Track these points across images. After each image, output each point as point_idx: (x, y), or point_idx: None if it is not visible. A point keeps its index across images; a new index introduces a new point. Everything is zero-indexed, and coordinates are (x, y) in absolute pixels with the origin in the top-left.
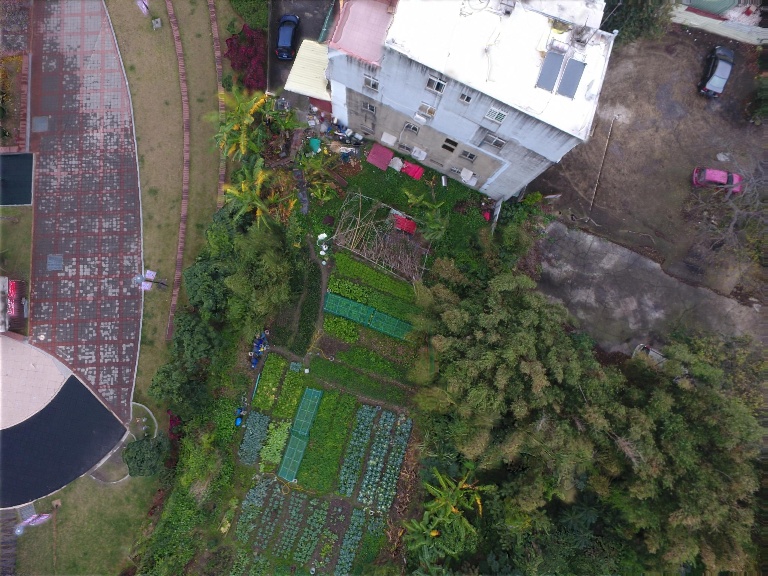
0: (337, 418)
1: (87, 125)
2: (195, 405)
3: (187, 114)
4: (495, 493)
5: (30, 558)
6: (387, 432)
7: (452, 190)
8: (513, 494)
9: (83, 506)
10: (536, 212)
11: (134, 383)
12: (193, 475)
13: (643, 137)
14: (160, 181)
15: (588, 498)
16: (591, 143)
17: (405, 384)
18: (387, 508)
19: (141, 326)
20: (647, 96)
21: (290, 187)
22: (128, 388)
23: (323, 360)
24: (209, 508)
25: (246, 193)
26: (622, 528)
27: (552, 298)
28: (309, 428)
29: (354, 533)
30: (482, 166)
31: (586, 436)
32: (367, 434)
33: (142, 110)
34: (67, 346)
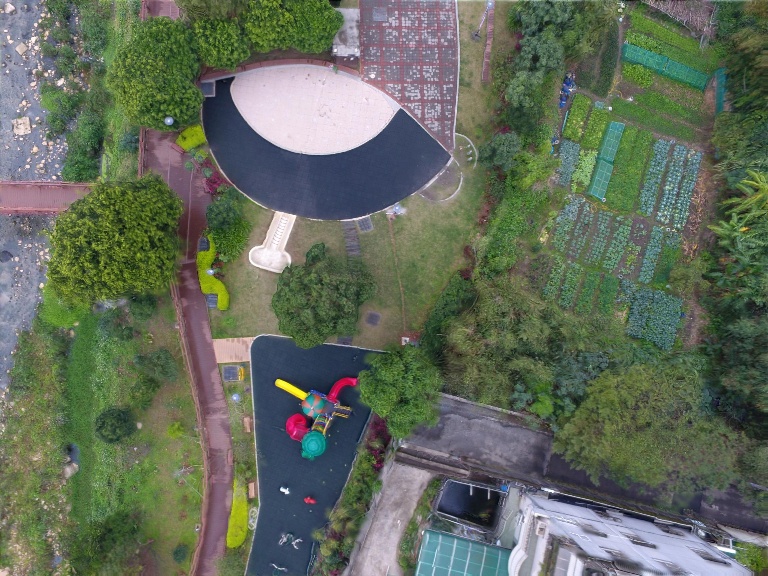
0: (638, 149)
1: None
2: None
3: None
4: None
5: (374, 259)
6: (681, 162)
7: None
8: None
9: (416, 218)
10: None
11: (455, 117)
12: (537, 174)
13: None
14: None
15: None
16: None
17: (693, 124)
18: (682, 226)
19: (459, 70)
20: None
21: None
22: (450, 121)
23: (623, 101)
24: None
25: None
26: None
27: None
28: (614, 156)
29: (655, 245)
30: None
31: None
32: (664, 163)
33: None
34: (395, 84)
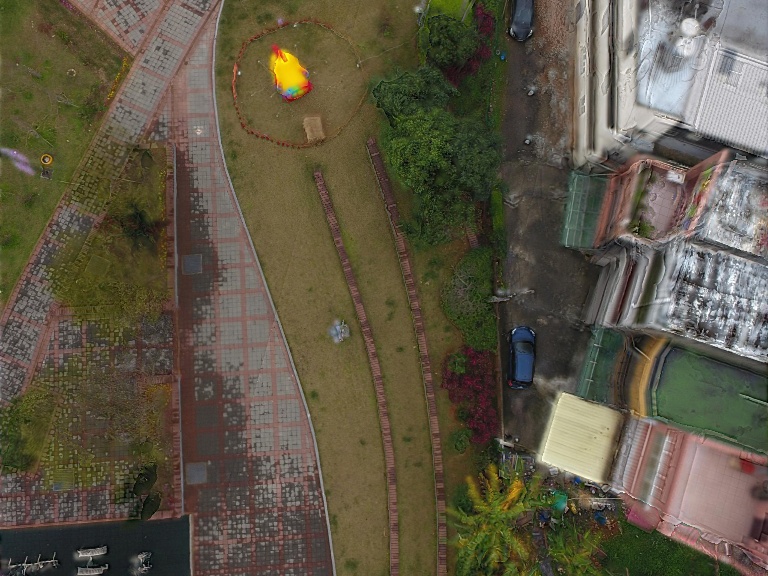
0: None
1: (258, 473)
2: None
3: (391, 459)
4: None
5: None
6: None
7: (736, 558)
8: None
9: None
10: None
11: None
12: None
13: None
14: (359, 551)
15: None
16: None
17: None
18: None
19: None
20: None
21: (532, 561)
22: None
23: None
24: None
25: None
26: None
27: None
28: None
29: None
30: None
31: None
32: None
33: (330, 452)
34: None
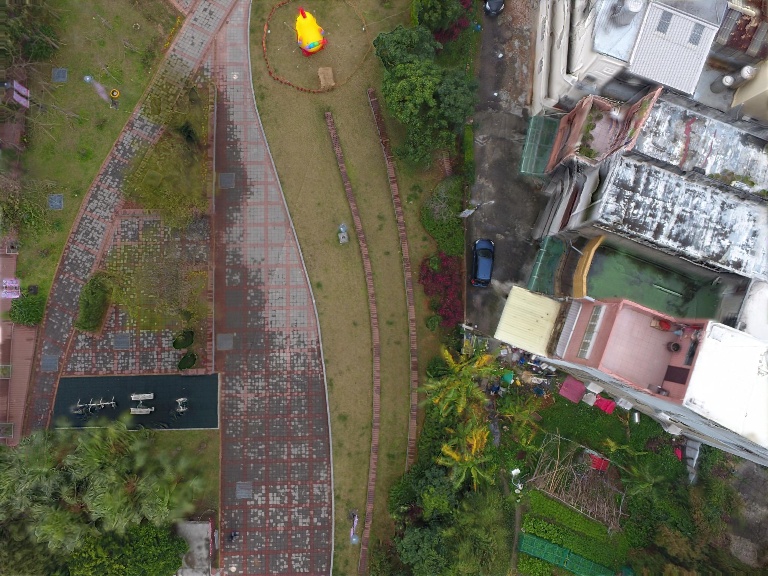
0: None
1: (273, 344)
2: None
3: (377, 338)
4: None
5: None
6: None
7: (644, 425)
8: None
9: None
10: None
11: None
12: None
13: None
14: (349, 406)
15: None
16: None
17: None
18: None
19: (332, 558)
20: None
21: (483, 420)
22: None
23: None
24: None
25: (468, 462)
26: None
27: (741, 539)
28: None
29: None
30: None
31: None
32: None
33: (330, 330)
34: None
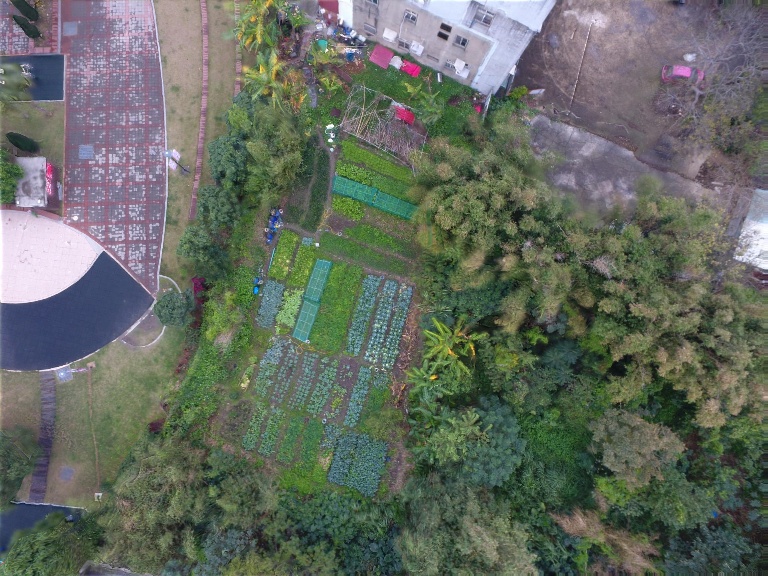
0: (345, 286)
1: (114, 29)
2: (218, 266)
3: (205, 19)
4: (487, 341)
5: (68, 412)
6: (390, 299)
7: (447, 86)
8: (503, 341)
9: (116, 367)
10: (522, 106)
11: (160, 258)
12: (217, 328)
13: (618, 40)
14: (181, 79)
15: (568, 343)
16: (571, 45)
17: (406, 257)
18: (390, 366)
19: (166, 208)
20: (621, 3)
21: (300, 83)
22: (155, 263)
23: (332, 236)
24: (230, 367)
25: (263, 75)
26: (598, 365)
27: (537, 181)
28: (320, 295)
29: (361, 387)
30: (473, 52)
31: (564, 267)
32: (372, 300)
33: (164, 16)
34: (99, 226)
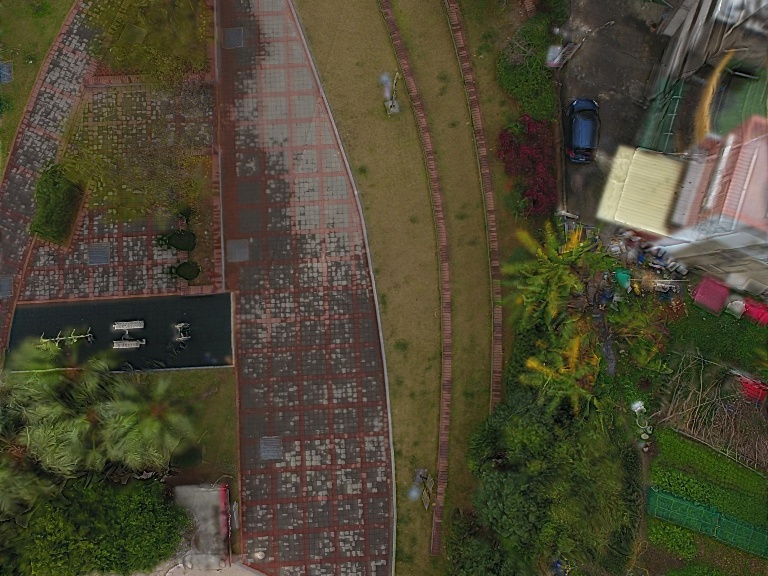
0: None
1: (303, 252)
2: None
3: (443, 238)
4: None
5: None
6: None
7: None
8: None
9: None
10: None
11: None
12: None
13: None
14: (409, 331)
15: None
16: None
17: None
18: None
19: (395, 536)
20: None
21: (593, 342)
22: None
23: None
24: None
25: (595, 387)
26: None
27: None
28: None
29: None
30: None
31: None
32: None
33: (379, 231)
34: (296, 567)
